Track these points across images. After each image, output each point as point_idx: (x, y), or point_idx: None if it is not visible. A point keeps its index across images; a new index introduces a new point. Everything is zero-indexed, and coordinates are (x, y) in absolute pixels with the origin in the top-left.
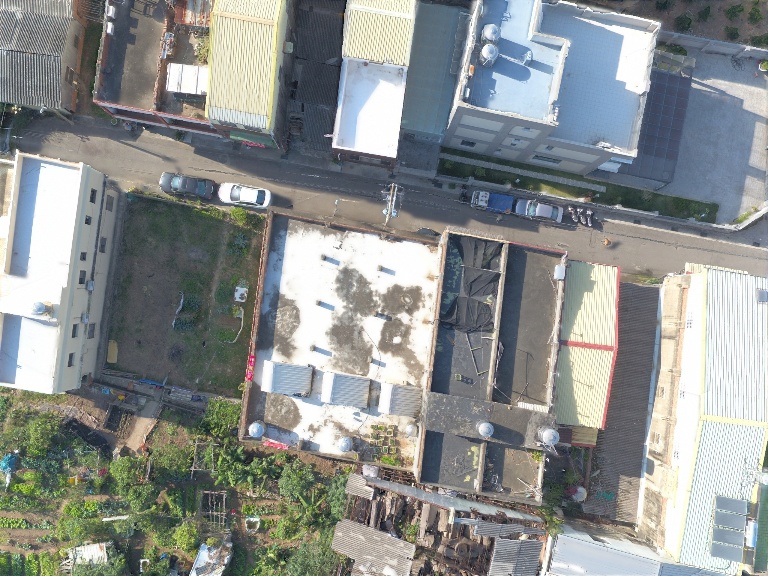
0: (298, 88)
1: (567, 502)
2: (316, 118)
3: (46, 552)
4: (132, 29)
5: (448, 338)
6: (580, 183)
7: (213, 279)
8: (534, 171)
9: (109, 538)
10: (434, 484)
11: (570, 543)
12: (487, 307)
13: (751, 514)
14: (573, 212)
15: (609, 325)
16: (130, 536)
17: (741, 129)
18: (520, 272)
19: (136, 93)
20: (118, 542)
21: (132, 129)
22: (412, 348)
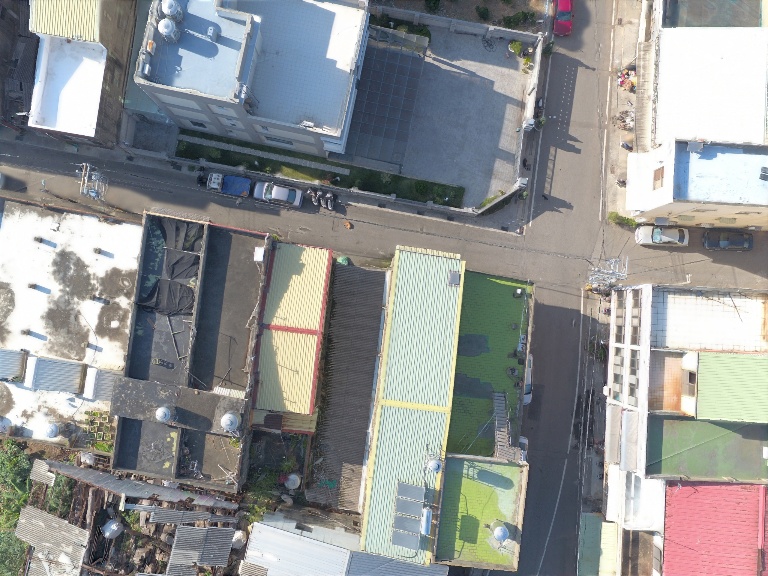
0: (17, 67)
1: None
2: None
3: None
4: None
5: (149, 321)
6: (323, 165)
7: None
8: (275, 153)
9: None
10: (128, 470)
11: (265, 531)
12: (190, 290)
13: (435, 501)
14: (314, 195)
15: (315, 309)
16: None
17: (491, 111)
18: (224, 254)
19: None
20: None
21: None
22: None
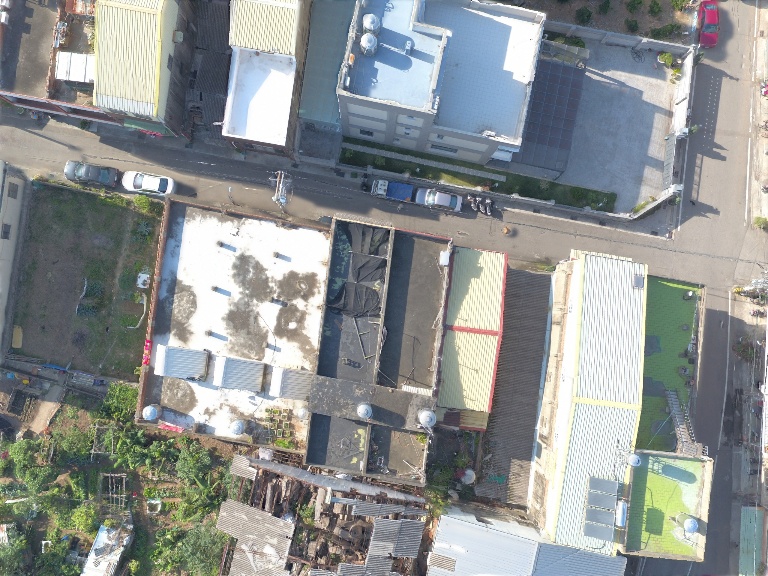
0: (197, 78)
1: (461, 485)
2: (214, 107)
3: None
4: (27, 18)
5: (336, 323)
6: (480, 172)
7: (117, 266)
8: (435, 160)
9: (12, 520)
10: (320, 466)
11: (452, 524)
12: (375, 292)
13: (624, 495)
14: (473, 201)
15: (495, 310)
16: (33, 518)
17: (640, 120)
18: (408, 258)
19: (31, 81)
20: (21, 524)
21: (38, 118)
22: (307, 333)
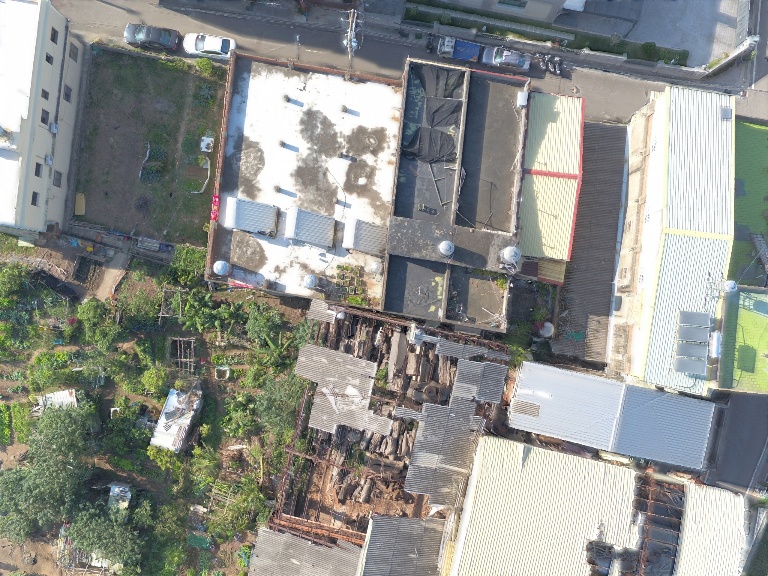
0: None
1: (536, 345)
2: None
3: (17, 403)
4: None
5: (411, 169)
6: (548, 31)
7: (179, 130)
8: (501, 19)
9: (80, 389)
10: (398, 313)
11: (535, 369)
12: (450, 137)
13: None
14: (541, 59)
15: (573, 154)
16: (100, 385)
17: None
18: (483, 102)
19: None
20: (88, 392)
21: None
22: (377, 189)
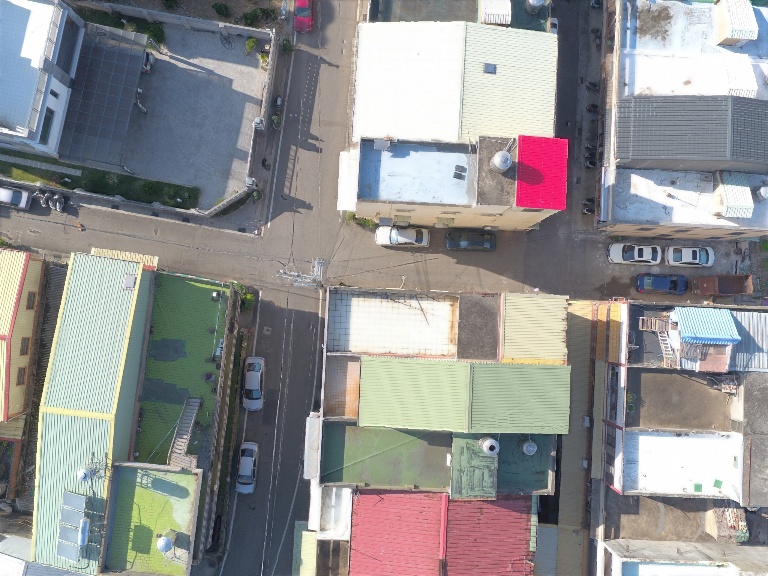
0: None
1: None
2: None
3: None
4: None
5: None
6: (54, 166)
7: None
8: (5, 154)
9: None
10: None
11: None
12: None
13: (104, 511)
14: (43, 197)
15: (6, 313)
16: None
17: (229, 110)
18: None
19: None
20: None
21: None
22: None
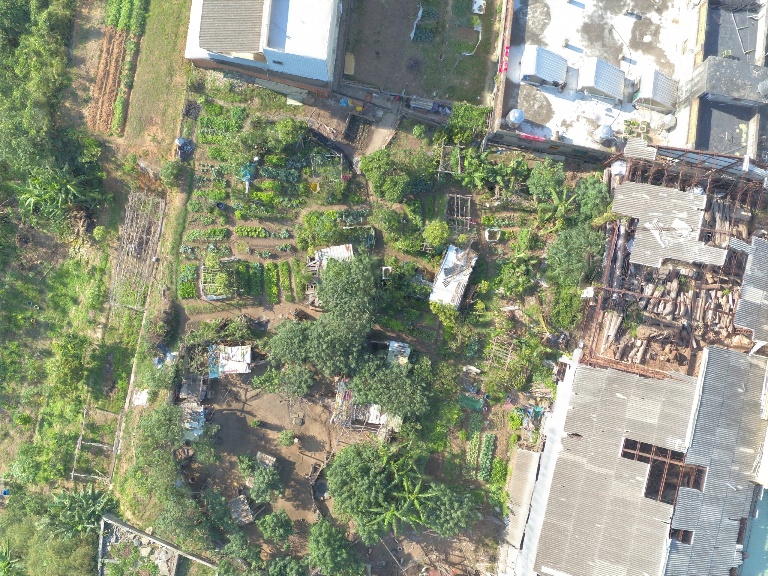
0: None
1: None
2: None
3: (285, 261)
4: None
5: (714, 17)
6: None
7: None
8: None
9: None
10: None
11: None
12: None
13: None
14: None
15: None
16: (371, 244)
17: None
18: None
19: None
20: (358, 252)
21: None
22: (662, 47)
